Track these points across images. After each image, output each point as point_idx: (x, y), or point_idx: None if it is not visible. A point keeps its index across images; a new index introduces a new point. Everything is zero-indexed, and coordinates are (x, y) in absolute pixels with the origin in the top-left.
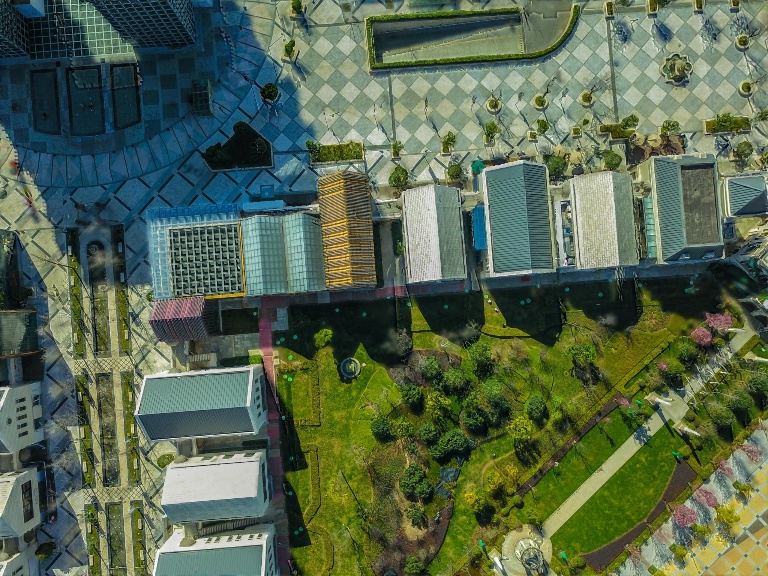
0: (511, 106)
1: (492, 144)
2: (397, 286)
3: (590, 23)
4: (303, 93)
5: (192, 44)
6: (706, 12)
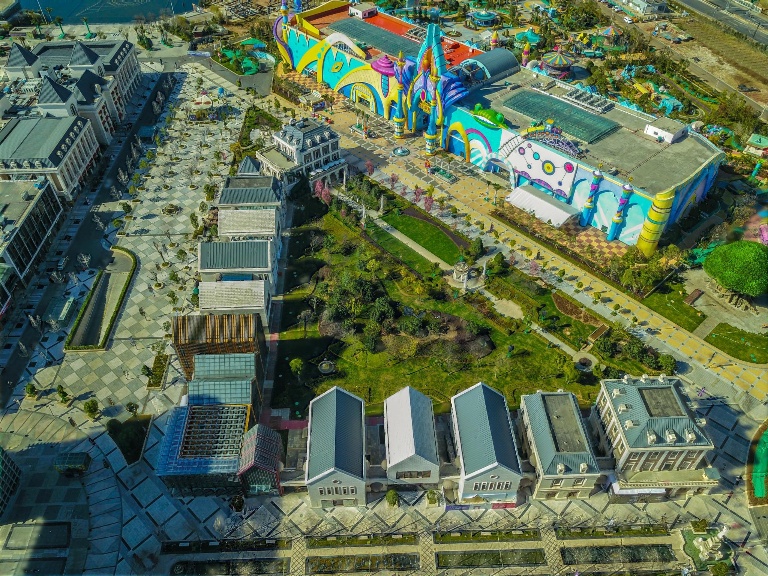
0: (163, 278)
1: (185, 287)
2: (270, 339)
3: (126, 243)
4: (102, 393)
5: (20, 474)
6: (143, 200)
